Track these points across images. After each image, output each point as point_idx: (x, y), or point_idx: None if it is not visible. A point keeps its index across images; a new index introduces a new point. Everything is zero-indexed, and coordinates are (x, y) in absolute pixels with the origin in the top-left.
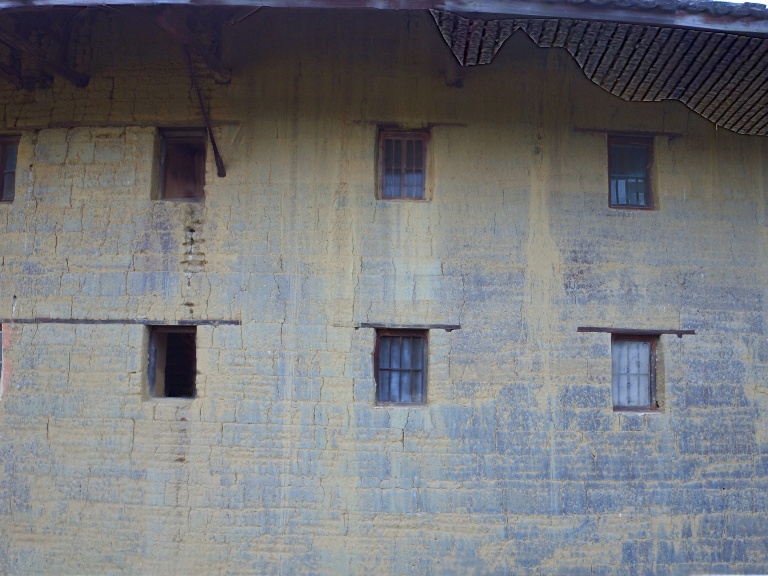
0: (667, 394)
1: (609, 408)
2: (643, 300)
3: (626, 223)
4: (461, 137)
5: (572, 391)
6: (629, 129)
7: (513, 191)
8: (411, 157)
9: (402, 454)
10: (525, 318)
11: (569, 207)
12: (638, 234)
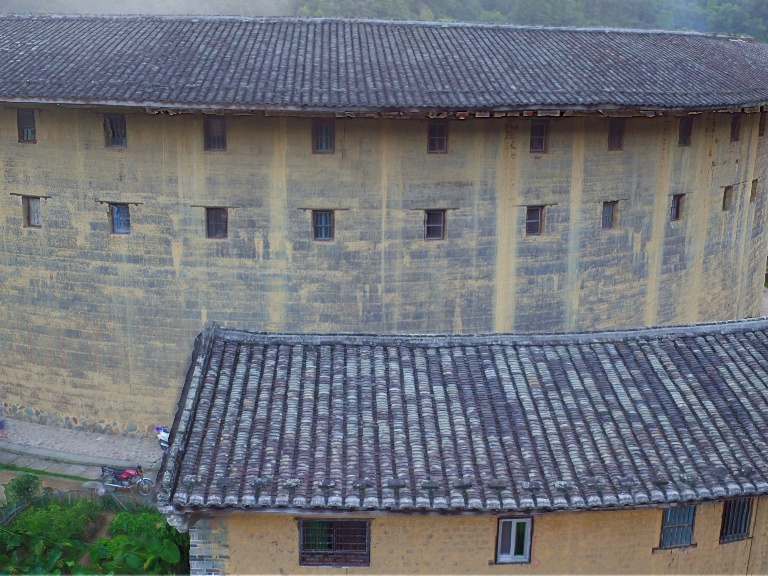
0: (42, 222)
1: (22, 226)
2: (32, 183)
3: (24, 150)
4: None
5: (10, 219)
6: (25, 107)
7: None
8: None
9: None
10: None
11: (4, 142)
12: (29, 155)
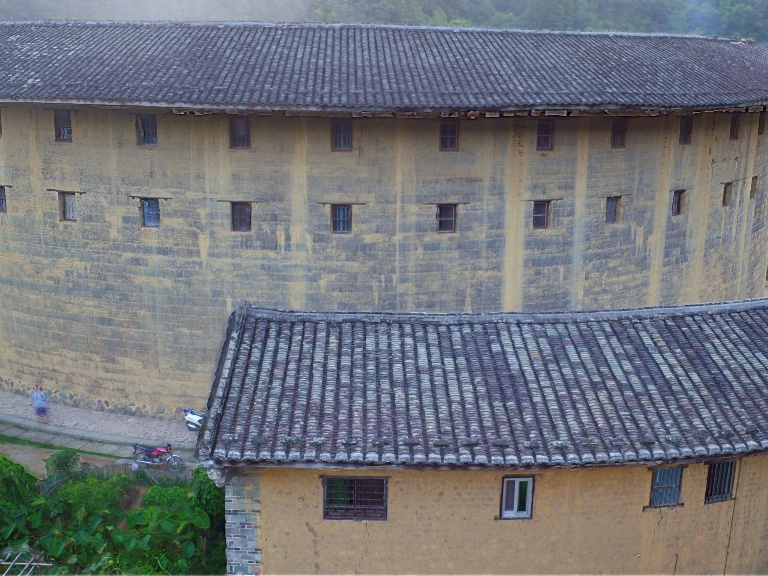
0: (77, 216)
1: (58, 220)
2: (68, 179)
3: (61, 148)
4: (8, 112)
5: (46, 213)
6: (62, 108)
7: (24, 134)
8: (0, 118)
9: (2, 231)
10: (31, 184)
11: (42, 141)
12: (65, 153)
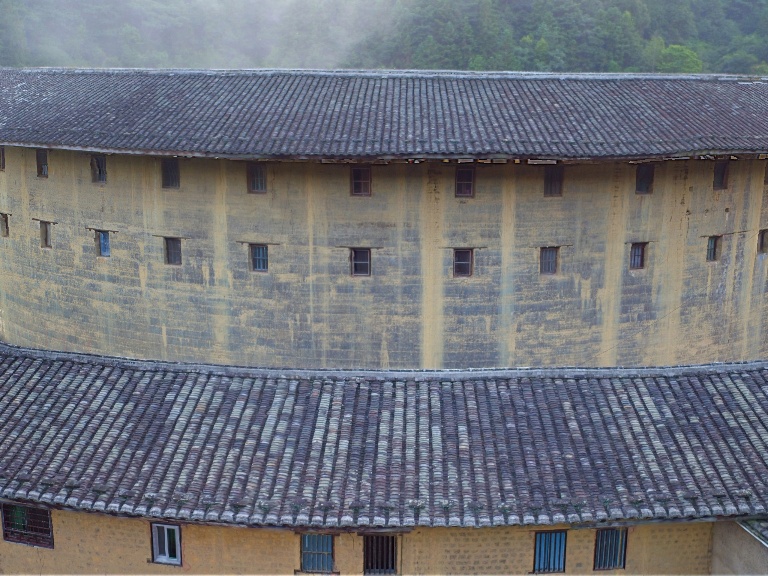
0: None
1: None
2: None
3: None
4: None
5: None
6: None
7: (18, 170)
8: None
9: None
10: None
11: None
12: None
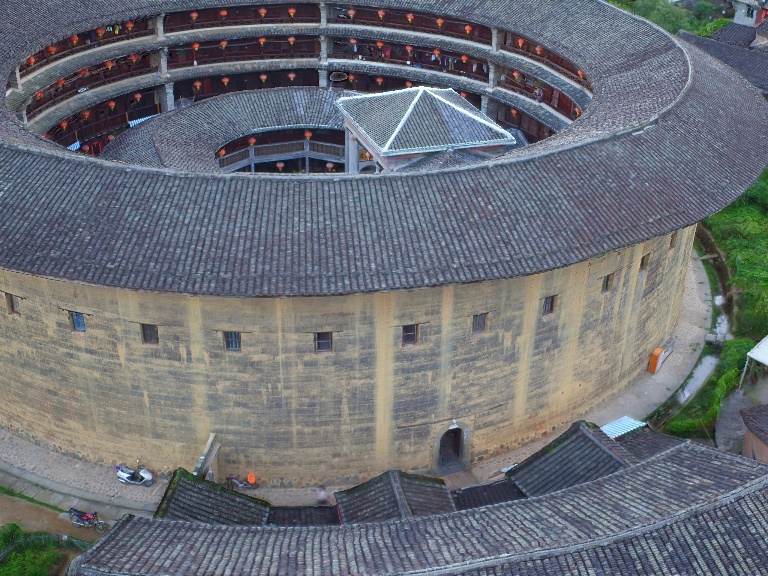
0: (21, 314)
1: None
2: (11, 286)
3: None
4: None
5: None
6: None
7: None
8: None
9: None
10: None
11: None
12: None
